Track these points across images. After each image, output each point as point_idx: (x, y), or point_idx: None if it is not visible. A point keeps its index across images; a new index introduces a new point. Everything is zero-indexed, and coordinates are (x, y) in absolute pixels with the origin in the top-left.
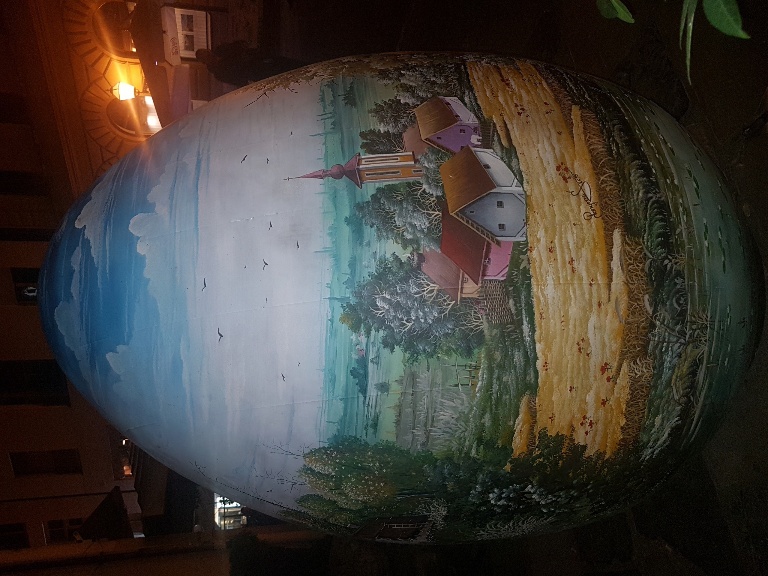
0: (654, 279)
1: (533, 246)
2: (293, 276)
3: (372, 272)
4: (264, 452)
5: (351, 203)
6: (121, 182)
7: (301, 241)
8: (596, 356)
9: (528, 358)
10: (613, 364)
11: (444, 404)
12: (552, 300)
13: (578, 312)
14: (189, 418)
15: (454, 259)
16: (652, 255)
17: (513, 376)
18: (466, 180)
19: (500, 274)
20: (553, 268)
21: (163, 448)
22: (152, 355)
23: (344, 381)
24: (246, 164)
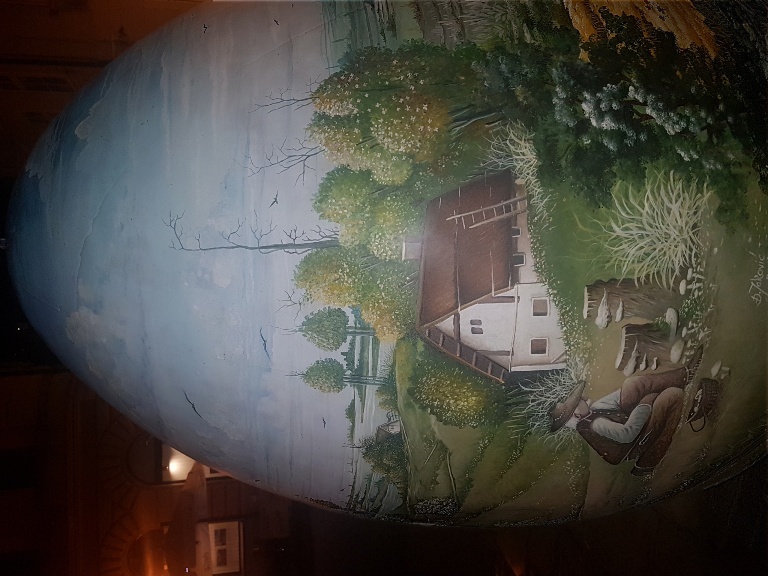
0: None
1: None
2: None
3: None
4: (260, 118)
5: None
6: None
7: None
8: None
9: None
10: None
11: None
12: None
13: None
14: (165, 125)
15: None
16: None
17: None
18: None
19: None
20: None
21: (128, 223)
22: (128, 85)
23: (345, 0)
24: None
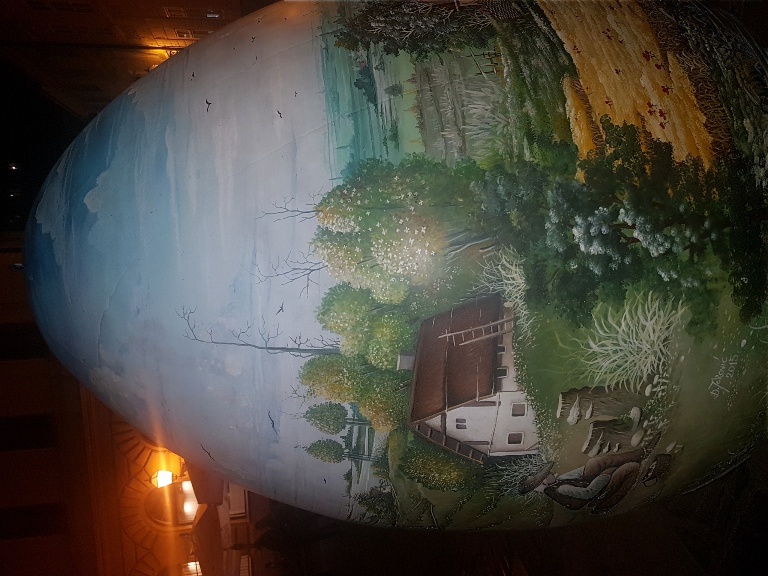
0: (662, 1)
1: None
2: (282, 34)
3: (362, 9)
4: (266, 226)
5: None
6: None
7: (289, 16)
8: (631, 44)
9: (552, 43)
10: (655, 53)
11: (471, 95)
12: (558, 3)
13: (591, 11)
14: (174, 219)
15: None
16: None
17: (542, 59)
18: None
19: None
20: None
21: (143, 308)
22: (134, 161)
23: (349, 95)
24: None
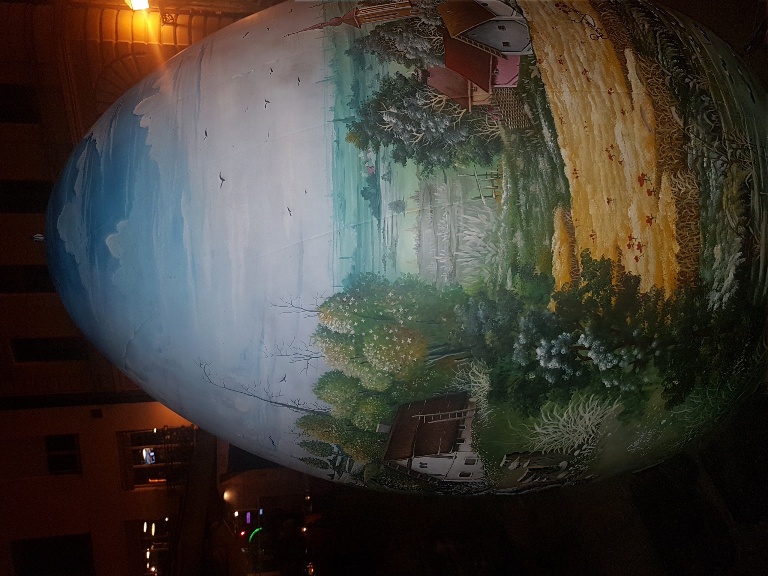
0: (678, 93)
1: (541, 59)
2: (295, 107)
3: (376, 91)
4: (273, 315)
5: (351, 39)
6: (129, 92)
7: (302, 76)
8: (630, 165)
9: (554, 164)
10: (651, 175)
11: (468, 221)
12: (570, 106)
13: (601, 118)
14: (191, 289)
15: (460, 71)
16: (670, 73)
17: (540, 185)
18: (464, 13)
19: (510, 82)
20: (566, 77)
21: (165, 350)
22: (152, 221)
23: (355, 205)
24: (248, 38)
